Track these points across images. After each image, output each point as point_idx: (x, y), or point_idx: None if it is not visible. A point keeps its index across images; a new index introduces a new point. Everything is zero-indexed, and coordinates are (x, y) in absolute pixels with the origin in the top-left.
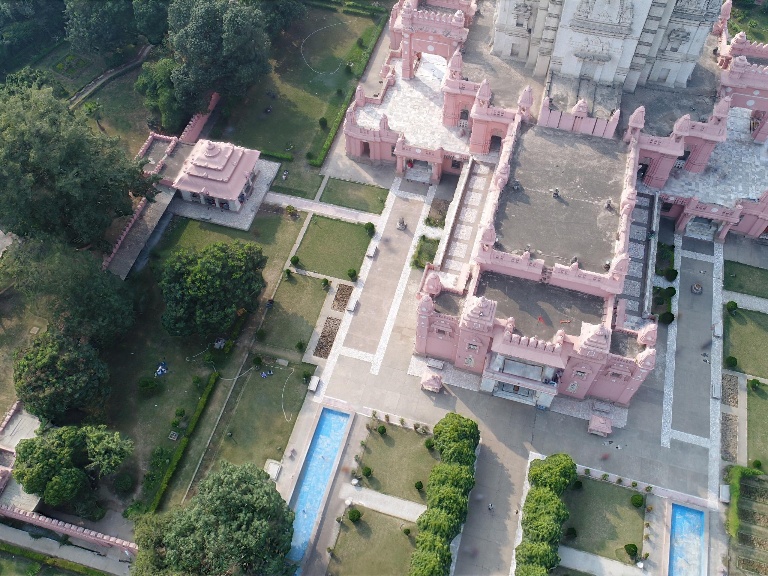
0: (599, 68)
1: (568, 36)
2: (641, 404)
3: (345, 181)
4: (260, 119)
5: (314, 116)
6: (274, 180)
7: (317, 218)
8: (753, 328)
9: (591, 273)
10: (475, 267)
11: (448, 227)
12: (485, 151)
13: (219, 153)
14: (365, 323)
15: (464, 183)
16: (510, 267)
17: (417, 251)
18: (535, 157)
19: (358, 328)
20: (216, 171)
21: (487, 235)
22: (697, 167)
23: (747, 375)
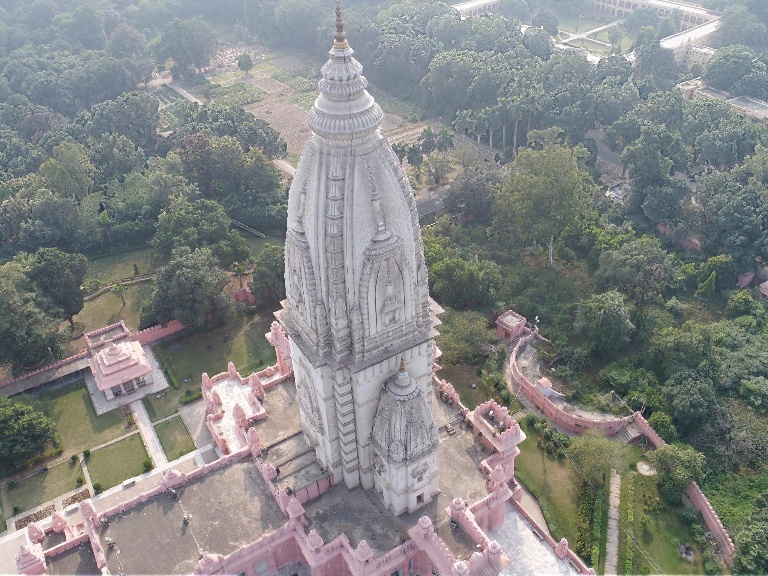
0: None
1: None
2: None
3: (183, 424)
4: (200, 350)
5: None
6: (153, 394)
7: (137, 436)
8: None
9: None
10: None
11: None
12: None
13: (115, 354)
14: None
15: None
16: None
17: None
18: (219, 485)
19: None
20: (105, 365)
21: None
22: None
23: None
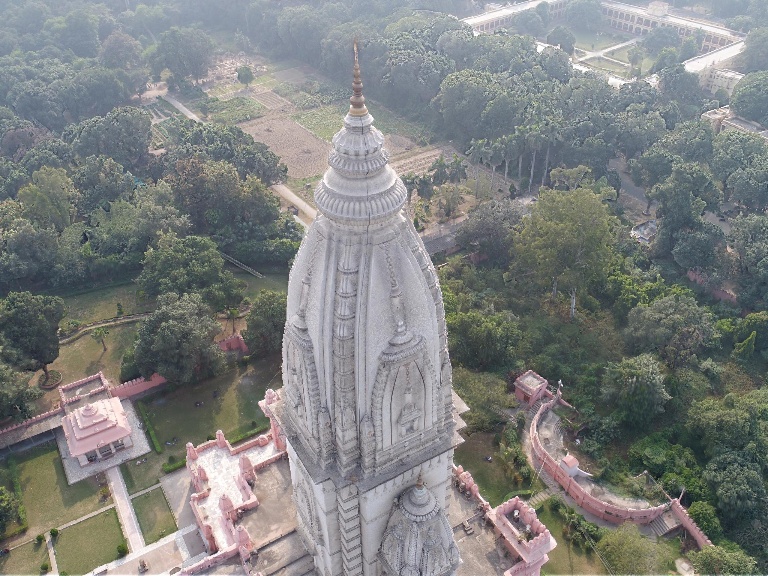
0: None
1: None
2: None
3: (165, 498)
4: (186, 407)
5: None
6: (132, 460)
7: (112, 512)
8: None
9: None
10: None
11: None
12: None
13: (91, 416)
14: None
15: None
16: None
17: None
18: None
19: None
20: None
21: None
22: None
23: None
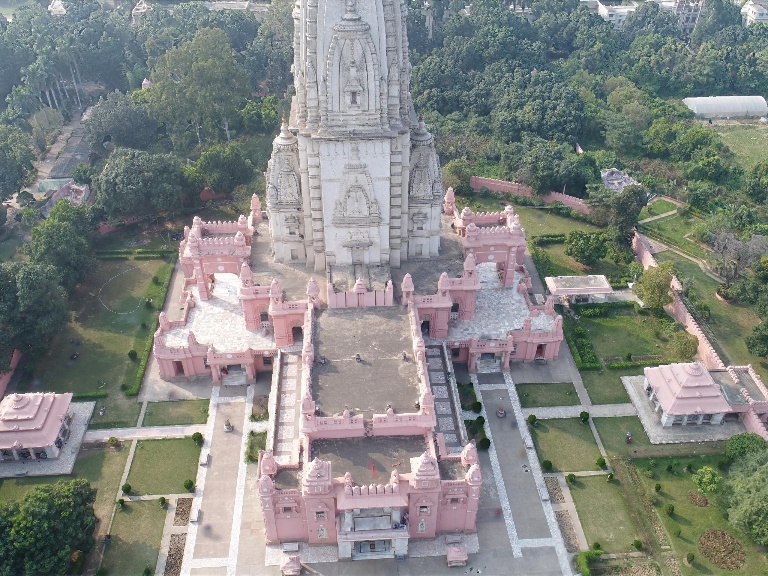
0: (366, 253)
1: (334, 233)
2: (486, 525)
3: (165, 402)
4: (67, 366)
5: (122, 352)
6: (91, 418)
7: (142, 443)
8: (555, 433)
9: (405, 415)
10: (304, 439)
11: (272, 415)
12: (290, 342)
13: (28, 403)
14: (212, 529)
15: (278, 373)
16: (335, 429)
17: (249, 447)
18: (333, 334)
19: (205, 536)
20: (27, 421)
21: (306, 404)
22: (468, 315)
23: (563, 473)
